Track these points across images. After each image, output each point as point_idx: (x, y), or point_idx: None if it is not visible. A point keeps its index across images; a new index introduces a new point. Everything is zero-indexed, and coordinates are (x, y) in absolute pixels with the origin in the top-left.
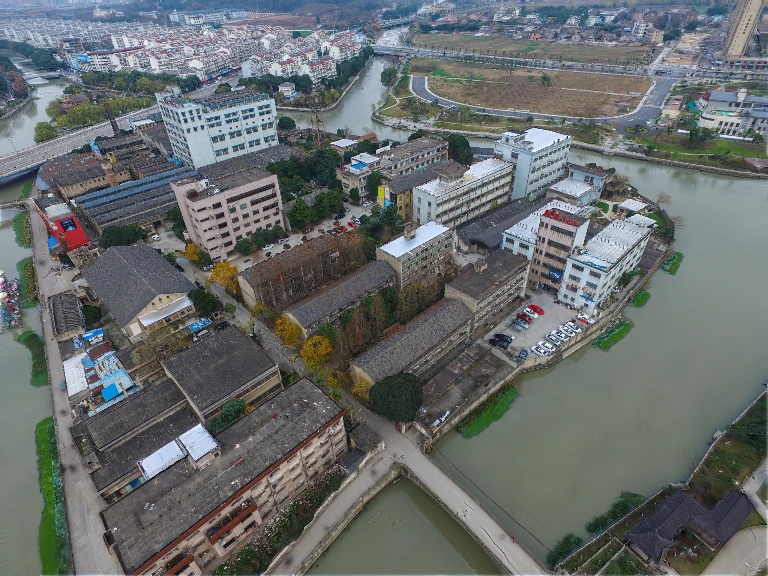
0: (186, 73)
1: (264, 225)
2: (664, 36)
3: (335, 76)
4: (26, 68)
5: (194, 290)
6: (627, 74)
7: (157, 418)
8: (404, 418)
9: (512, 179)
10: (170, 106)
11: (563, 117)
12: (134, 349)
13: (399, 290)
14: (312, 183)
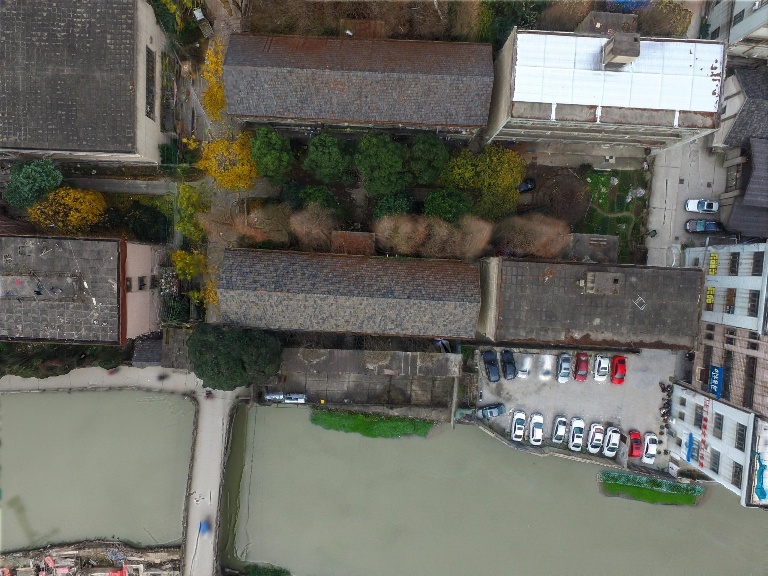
0: None
1: None
2: None
3: None
4: None
5: None
6: None
7: None
8: None
9: None
10: None
11: None
12: None
13: (484, 140)
14: None
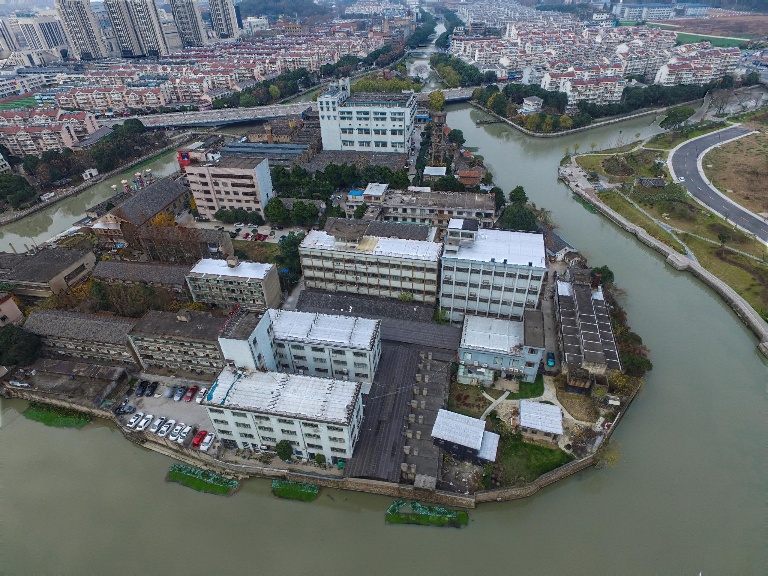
0: (488, 68)
1: (245, 207)
2: None
3: (616, 101)
4: (422, 44)
5: None
6: None
7: (7, 271)
8: None
9: (439, 279)
10: None
11: None
12: (77, 237)
13: None
14: None
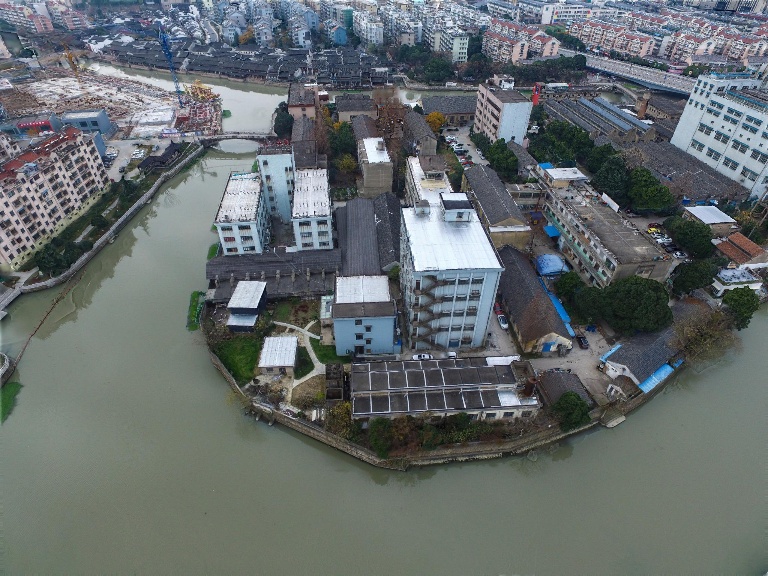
0: None
1: None
2: None
3: None
4: None
5: (417, 105)
6: None
7: None
8: None
9: None
10: None
11: None
12: (401, 105)
13: None
14: None
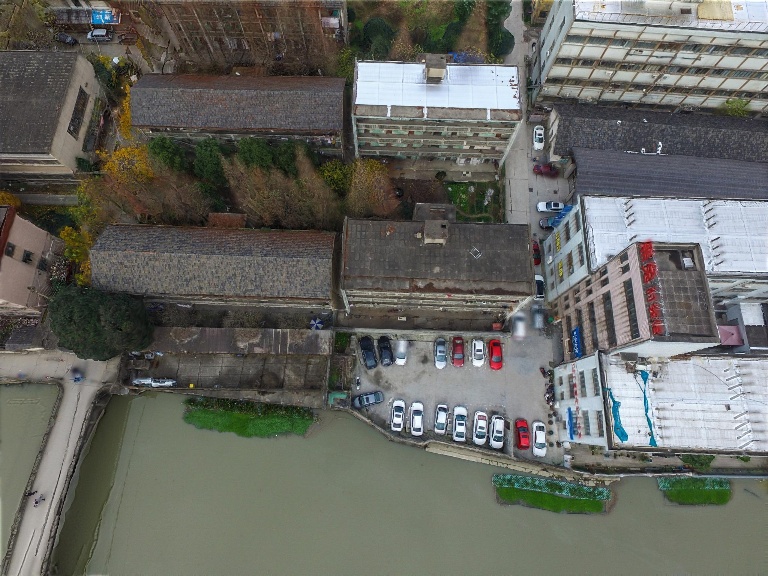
0: None
1: None
2: None
3: None
4: None
5: None
6: None
7: None
8: (77, 354)
9: None
10: None
11: None
12: (1, 4)
13: (353, 155)
14: None
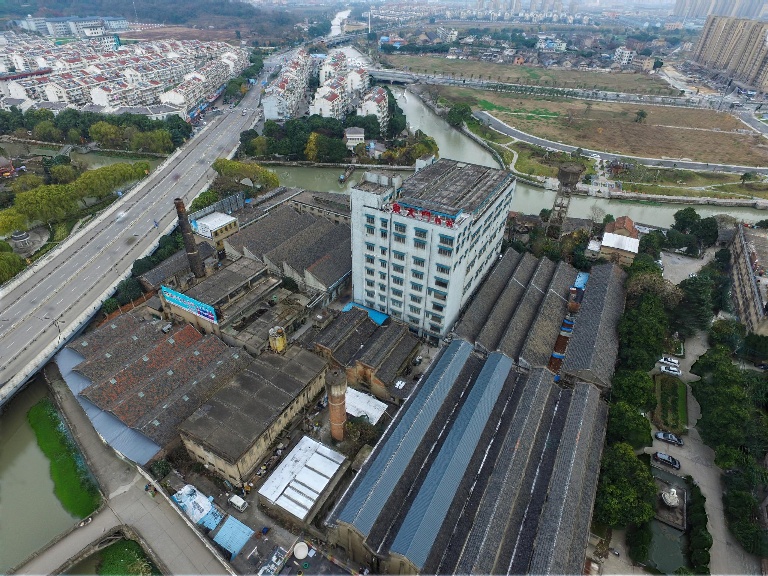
0: (162, 112)
1: None
2: (654, 64)
3: None
4: None
5: None
6: (693, 107)
7: None
8: None
9: None
10: (421, 221)
11: (744, 168)
12: None
13: None
14: (675, 336)
